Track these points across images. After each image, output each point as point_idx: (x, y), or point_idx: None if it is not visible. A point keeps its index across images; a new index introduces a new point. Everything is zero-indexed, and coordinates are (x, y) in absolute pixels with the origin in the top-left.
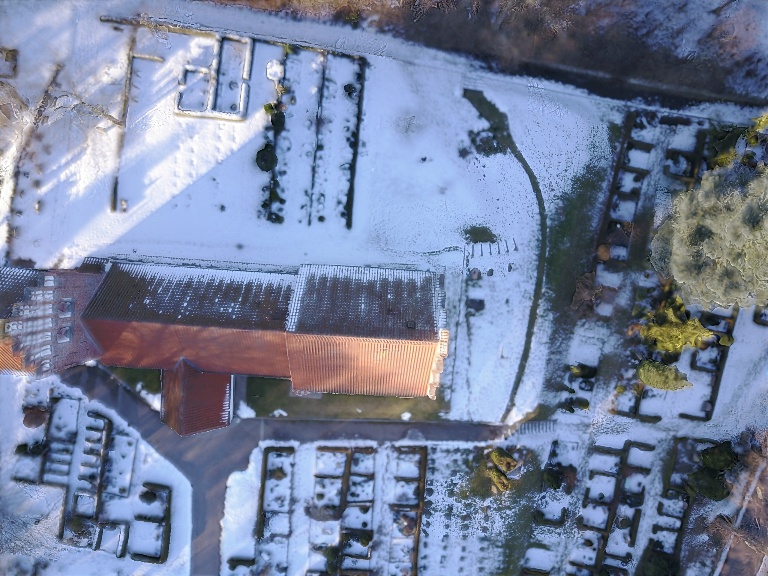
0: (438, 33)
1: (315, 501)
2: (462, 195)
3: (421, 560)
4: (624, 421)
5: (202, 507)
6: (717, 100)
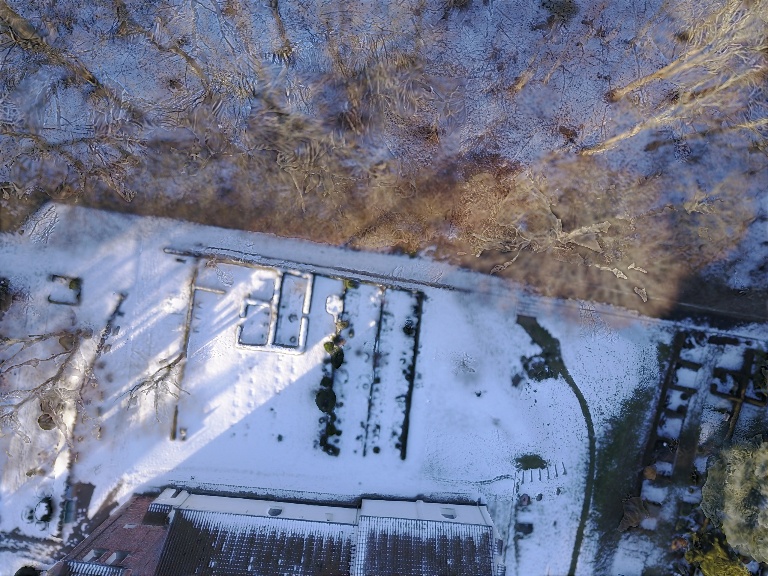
0: (494, 261)
1: None
2: (514, 425)
3: None
4: None
5: None
6: (765, 321)
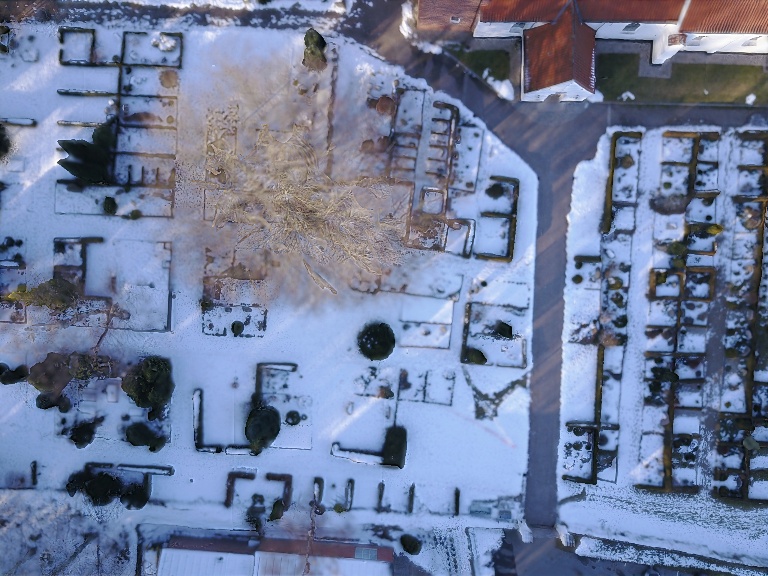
0: None
1: (662, 191)
2: None
3: (764, 256)
4: None
5: (548, 201)
6: None
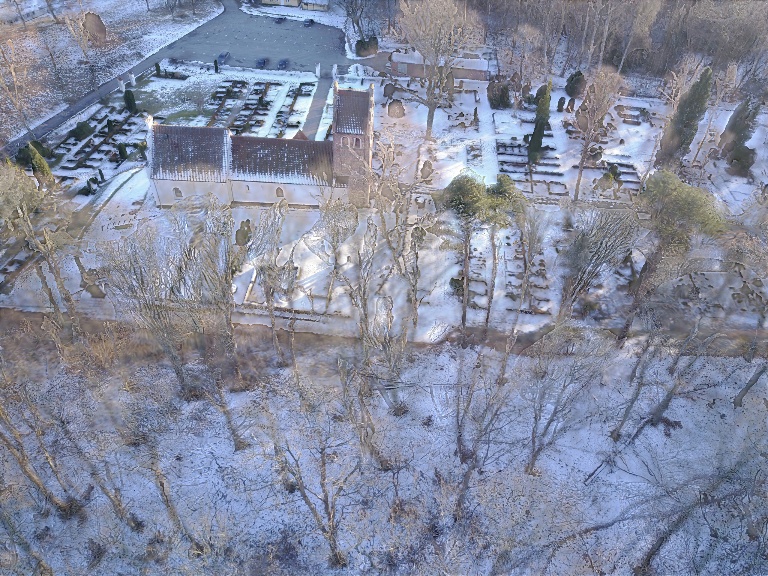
0: None
1: None
2: None
3: None
4: (72, 176)
5: None
6: None
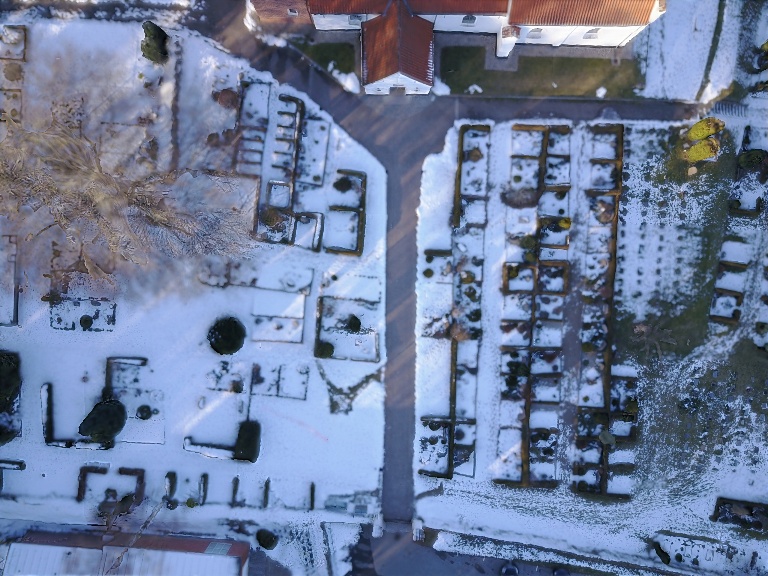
0: None
1: (512, 184)
2: None
3: (619, 250)
4: None
5: (397, 195)
6: None
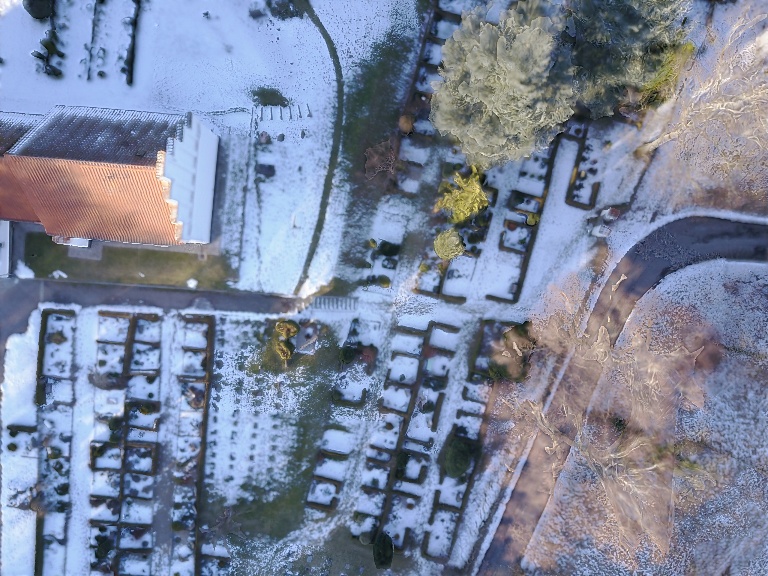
0: None
1: (97, 367)
2: (249, 54)
3: (211, 435)
4: (428, 301)
5: None
6: None
